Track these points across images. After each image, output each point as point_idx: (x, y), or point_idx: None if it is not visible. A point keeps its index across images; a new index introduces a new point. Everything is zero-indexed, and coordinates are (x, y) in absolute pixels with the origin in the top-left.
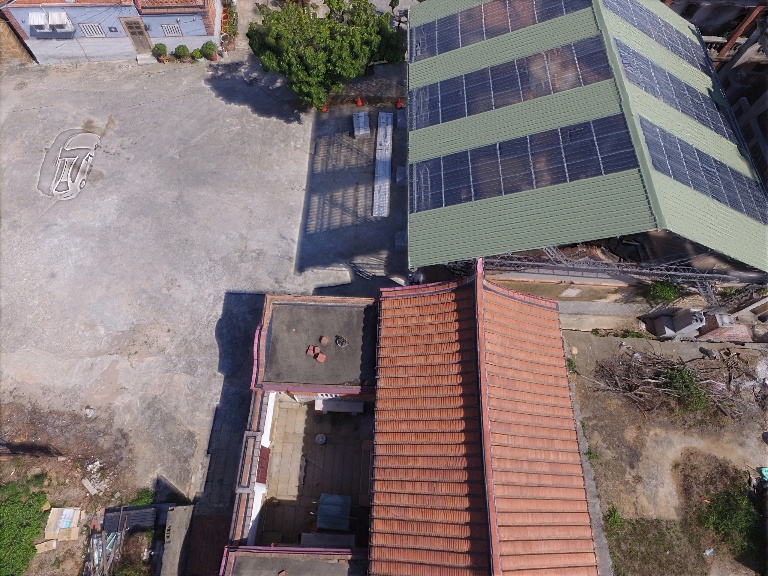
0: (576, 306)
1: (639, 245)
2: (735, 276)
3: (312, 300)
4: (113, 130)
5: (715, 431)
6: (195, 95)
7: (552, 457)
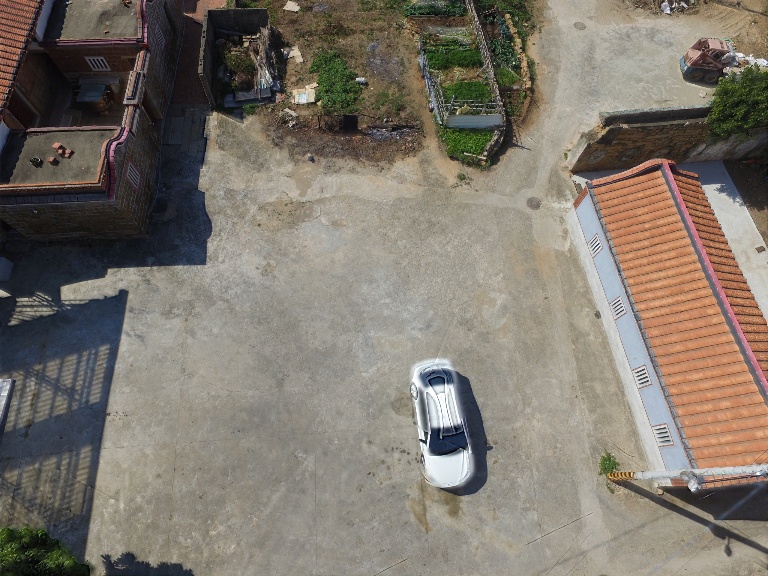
0: None
1: None
2: None
3: (52, 183)
4: (412, 499)
5: None
6: None
7: None
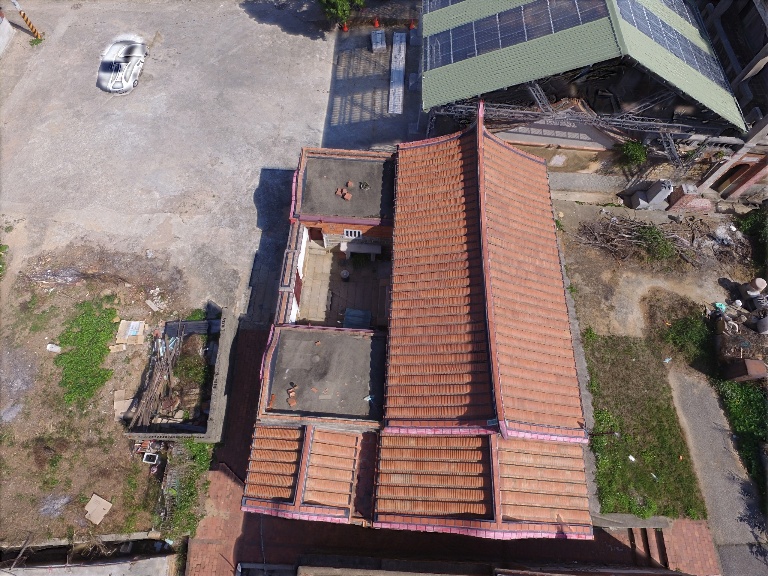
0: (563, 180)
1: (612, 96)
2: (691, 125)
3: (340, 152)
4: (160, 42)
5: (678, 276)
6: (231, 16)
7: (538, 263)
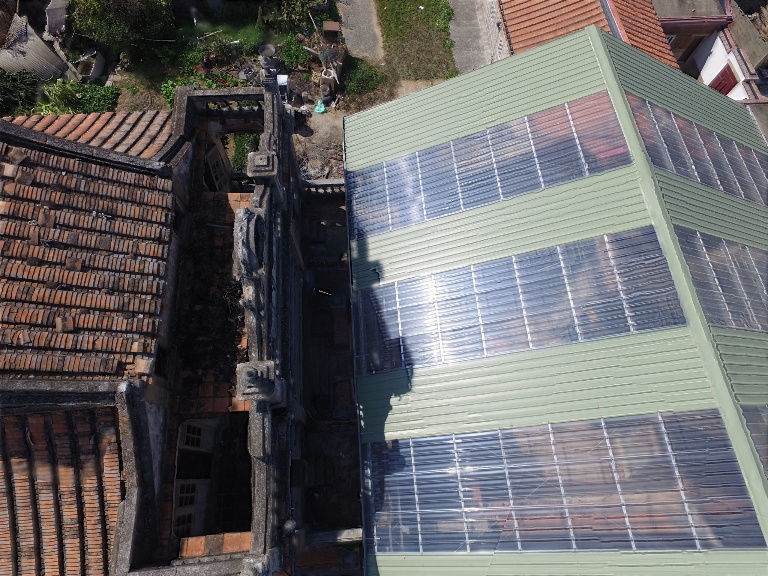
0: None
1: None
2: None
3: None
4: None
5: None
6: None
7: None
